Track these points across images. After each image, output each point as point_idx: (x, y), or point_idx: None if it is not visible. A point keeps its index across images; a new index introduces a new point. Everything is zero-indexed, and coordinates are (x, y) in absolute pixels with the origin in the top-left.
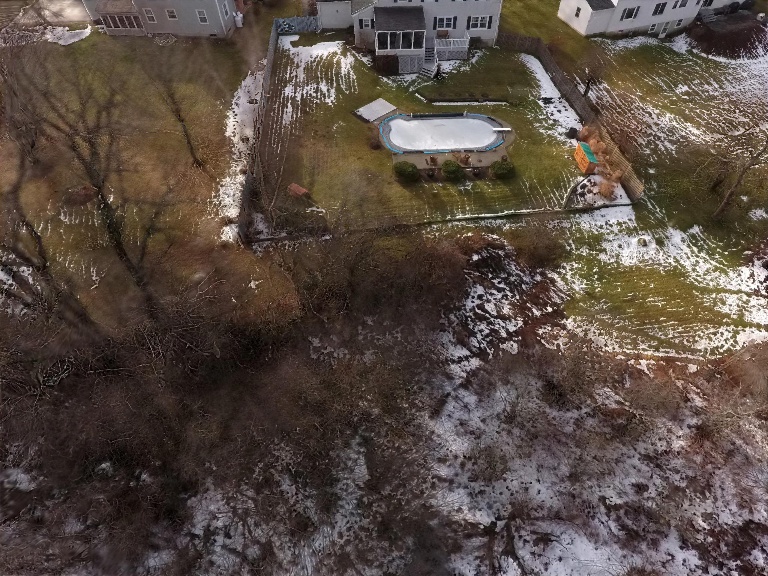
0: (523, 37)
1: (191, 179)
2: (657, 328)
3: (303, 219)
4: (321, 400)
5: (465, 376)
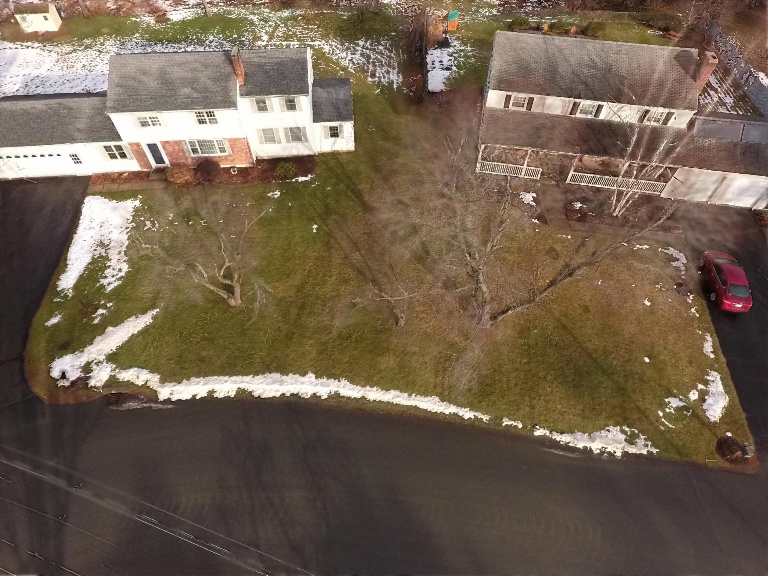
0: (449, 92)
1: (765, 51)
2: None
3: (663, 19)
4: None
5: None
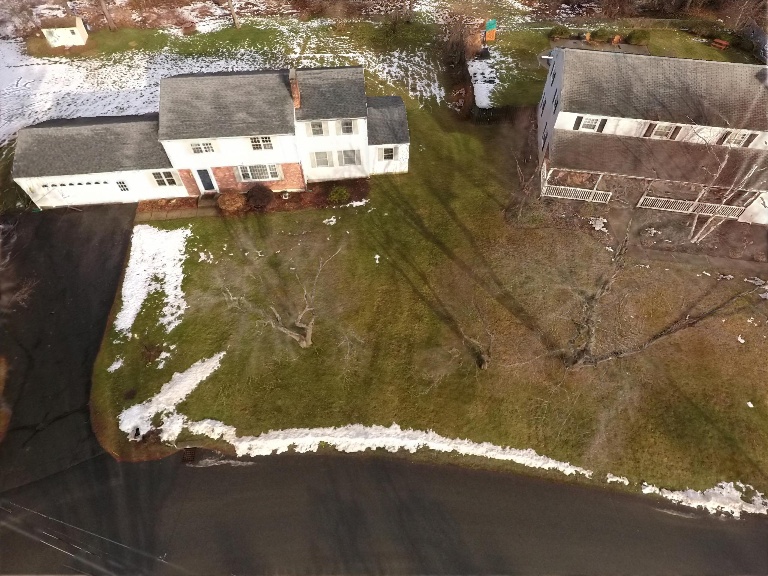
0: (501, 109)
1: None
2: (485, 2)
3: None
4: (661, 2)
5: (590, 3)
